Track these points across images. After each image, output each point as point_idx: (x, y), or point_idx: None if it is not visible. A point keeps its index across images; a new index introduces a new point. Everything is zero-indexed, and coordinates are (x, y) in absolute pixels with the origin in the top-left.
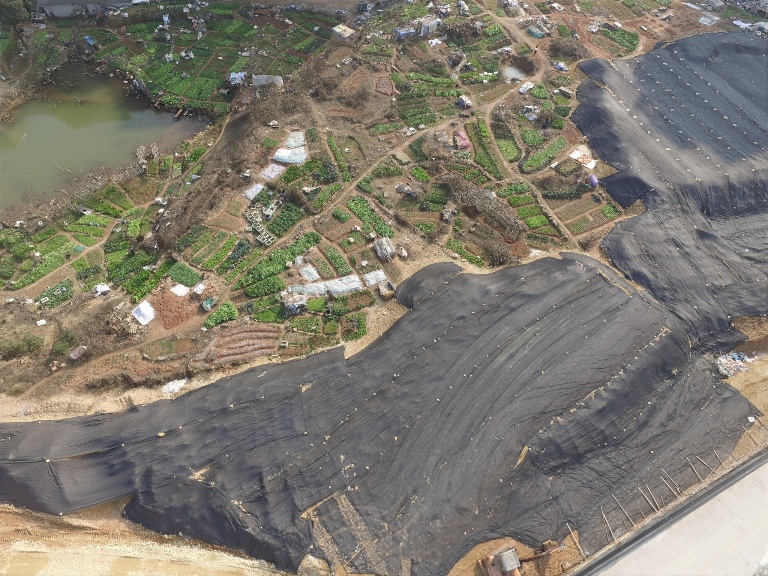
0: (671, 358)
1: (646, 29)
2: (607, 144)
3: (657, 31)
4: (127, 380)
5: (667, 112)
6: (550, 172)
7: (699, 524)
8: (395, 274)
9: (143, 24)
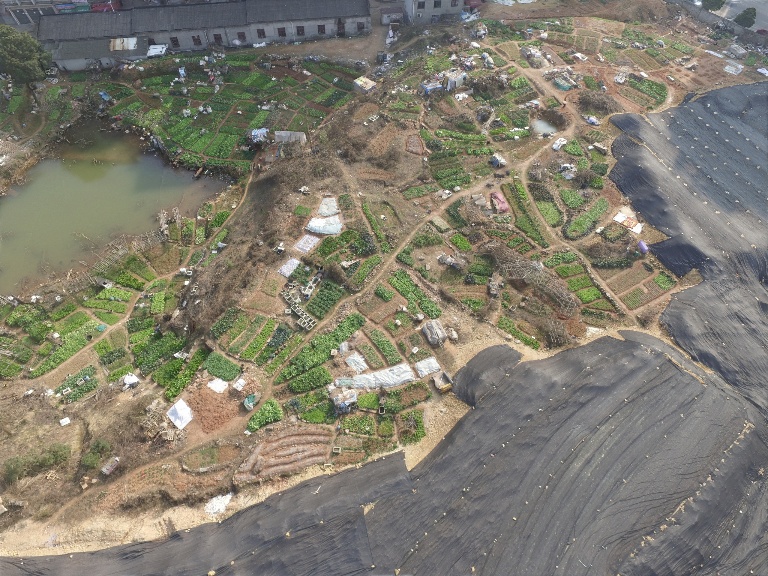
0: (757, 457)
1: (673, 79)
2: (653, 207)
3: (684, 81)
4: (166, 498)
5: (710, 171)
6: (596, 238)
7: None
8: (448, 361)
9: (158, 77)
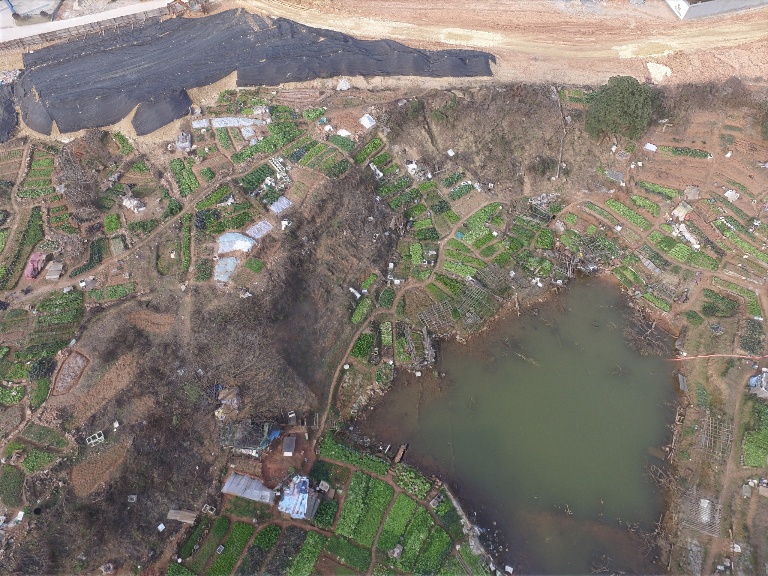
0: None
1: None
2: None
3: None
4: None
5: None
6: None
7: None
8: (185, 126)
9: None
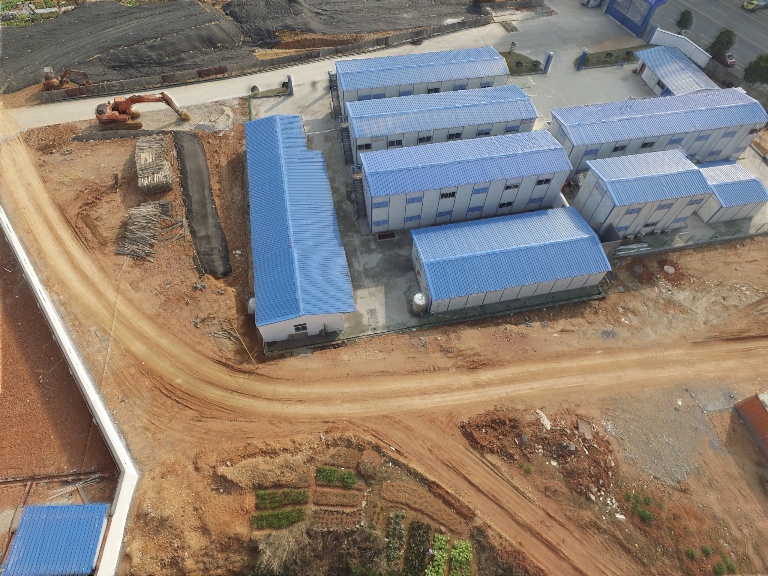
0: (217, 36)
1: None
2: None
3: None
4: None
5: None
6: None
7: (184, 89)
8: None
9: None
